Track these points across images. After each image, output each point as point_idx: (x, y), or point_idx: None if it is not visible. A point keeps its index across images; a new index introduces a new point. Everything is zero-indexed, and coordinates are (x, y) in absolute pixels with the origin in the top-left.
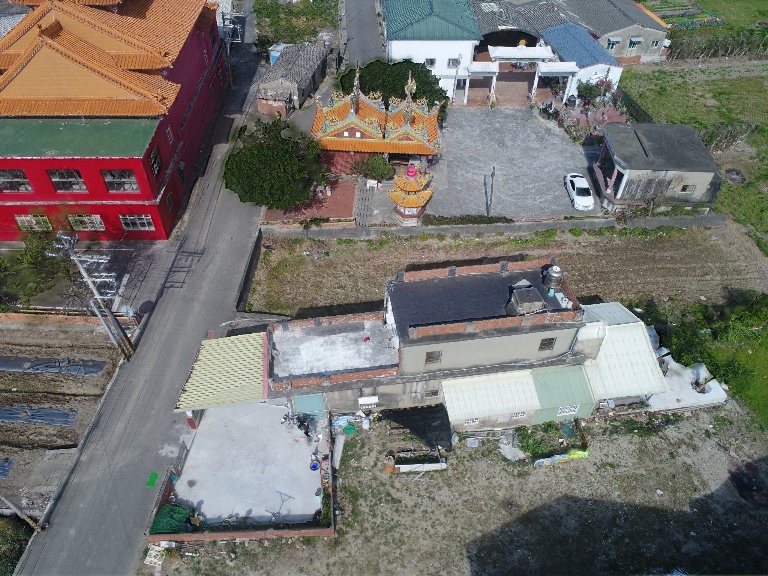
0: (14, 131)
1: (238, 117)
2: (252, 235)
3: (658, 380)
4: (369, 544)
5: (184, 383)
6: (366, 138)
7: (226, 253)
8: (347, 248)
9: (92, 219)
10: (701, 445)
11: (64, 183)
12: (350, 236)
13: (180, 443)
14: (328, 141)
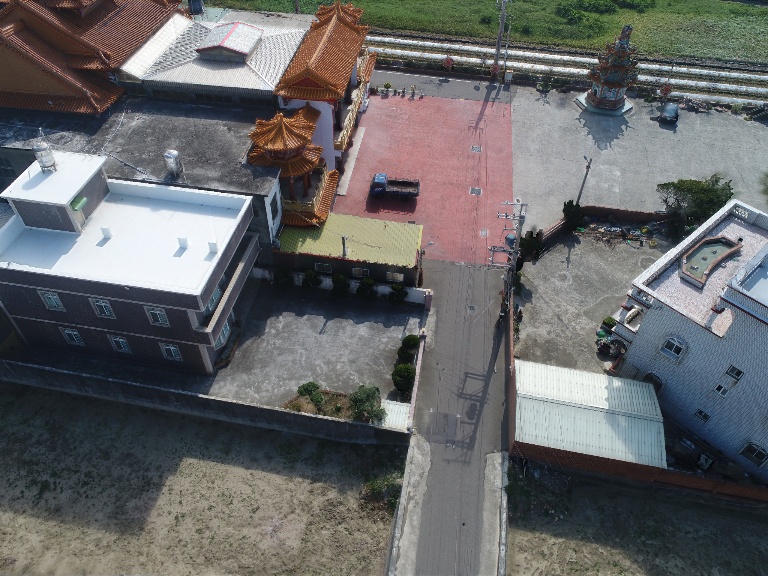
0: None
1: None
2: None
3: None
4: None
5: None
6: None
7: None
8: None
9: None
10: None
11: None
12: None
13: None
14: None
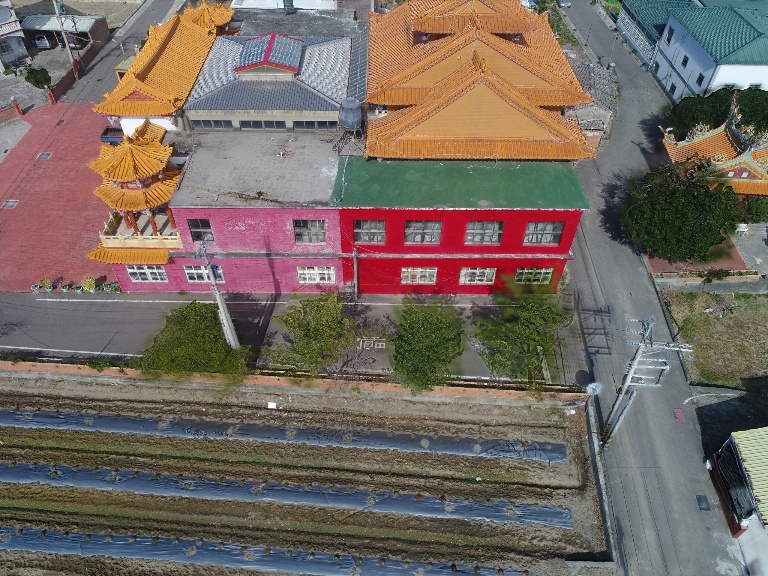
0: (422, 176)
1: None
2: (650, 290)
3: None
4: None
5: (751, 490)
6: (752, 179)
7: (635, 312)
8: (748, 304)
9: (485, 272)
10: None
11: (476, 235)
12: (748, 290)
13: (732, 557)
14: (707, 181)
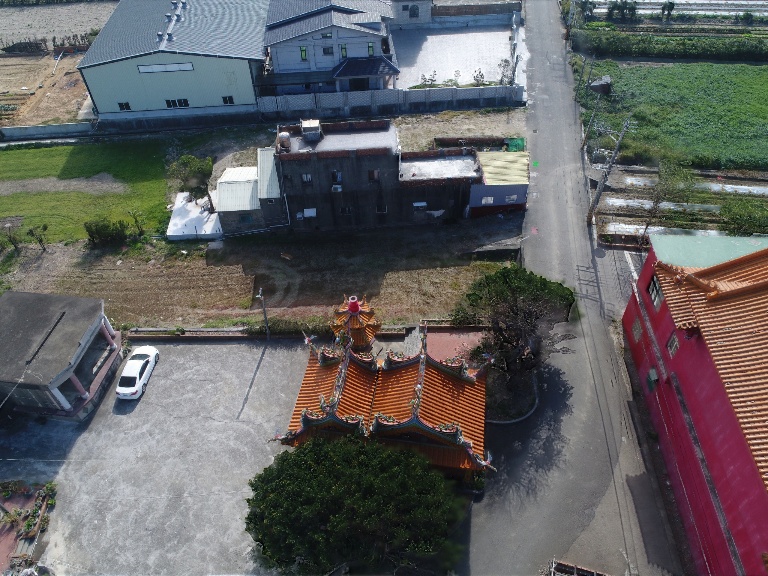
0: None
1: (644, 569)
2: None
3: (229, 170)
4: (416, 142)
5: None
6: None
7: None
8: None
9: None
10: (218, 173)
11: None
12: None
13: None
14: None
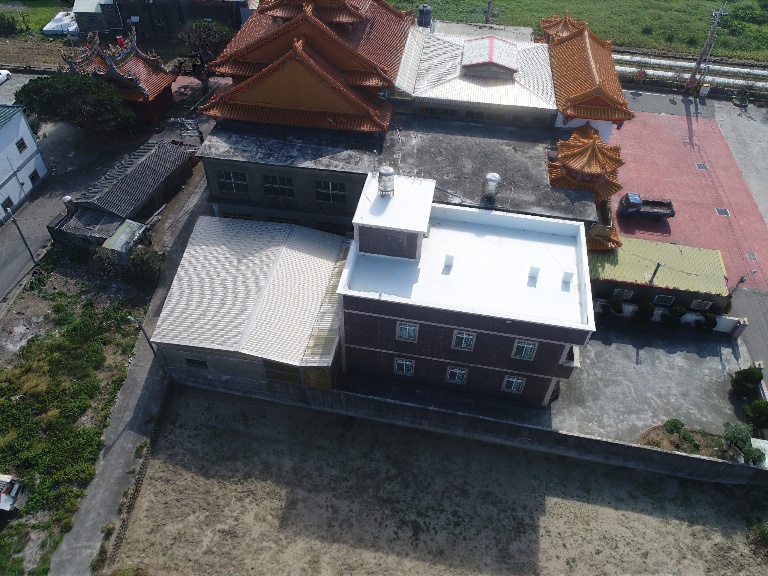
0: None
1: None
2: None
3: None
4: None
5: None
6: None
7: None
8: None
9: None
10: None
11: None
12: None
13: None
14: None
